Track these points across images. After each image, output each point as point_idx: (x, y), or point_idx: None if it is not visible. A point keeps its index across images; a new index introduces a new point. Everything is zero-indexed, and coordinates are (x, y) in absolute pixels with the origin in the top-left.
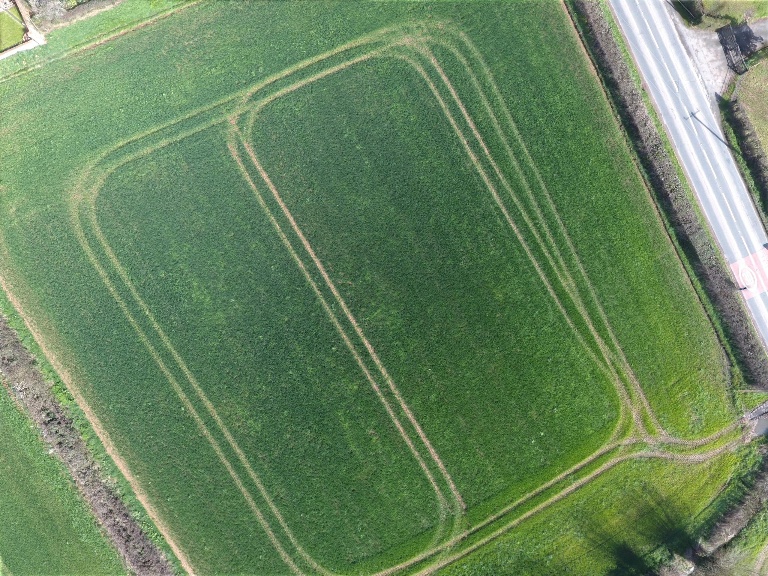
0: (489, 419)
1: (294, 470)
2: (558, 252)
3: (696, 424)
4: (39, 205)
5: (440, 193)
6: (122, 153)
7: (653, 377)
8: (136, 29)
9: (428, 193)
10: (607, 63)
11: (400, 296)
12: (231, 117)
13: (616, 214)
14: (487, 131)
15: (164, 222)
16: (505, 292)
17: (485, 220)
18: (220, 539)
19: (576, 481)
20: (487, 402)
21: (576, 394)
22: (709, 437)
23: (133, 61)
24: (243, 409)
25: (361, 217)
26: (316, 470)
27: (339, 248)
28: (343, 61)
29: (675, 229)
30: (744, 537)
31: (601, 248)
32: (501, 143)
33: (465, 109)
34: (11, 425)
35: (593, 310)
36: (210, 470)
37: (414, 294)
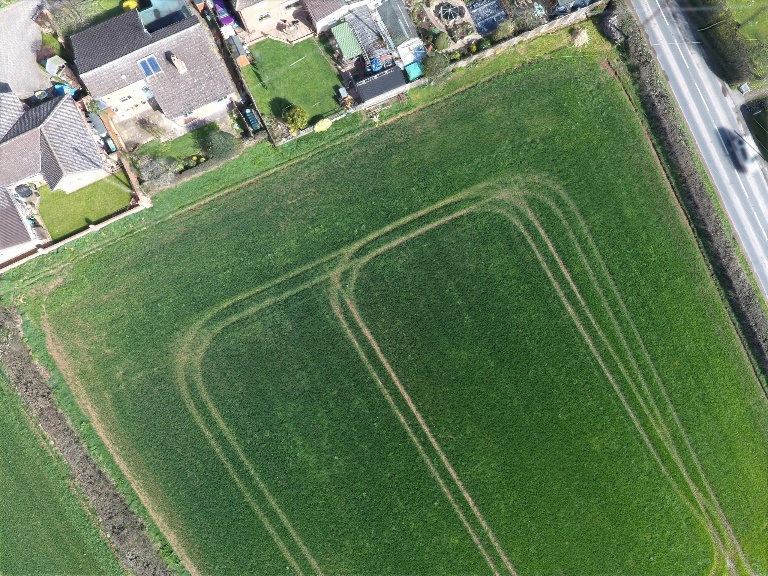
0: (587, 569)
1: None
2: (653, 401)
3: None
4: (146, 368)
5: (538, 346)
6: (228, 314)
7: (746, 522)
8: (240, 188)
9: (527, 346)
10: (701, 216)
11: (500, 449)
12: (334, 274)
13: (709, 362)
14: (584, 283)
15: (269, 382)
16: (602, 442)
17: (582, 372)
18: None
19: None
20: (585, 552)
21: (672, 542)
22: None
23: (238, 222)
24: (347, 566)
25: (462, 372)
26: None
27: (440, 403)
28: (443, 217)
29: (766, 376)
30: None
31: (695, 396)
32: (597, 295)
33: (562, 261)
34: None
35: (688, 458)
36: None
37: (514, 447)
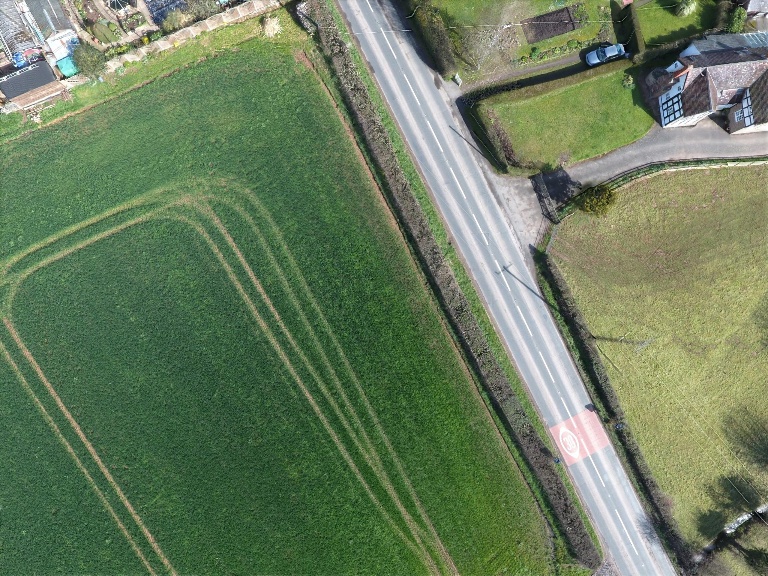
0: None
1: None
2: (359, 423)
3: None
4: None
5: (225, 365)
6: None
7: (468, 554)
8: None
9: (212, 366)
10: (405, 220)
11: (182, 480)
12: None
13: (422, 379)
14: (277, 296)
15: None
16: (300, 470)
17: (276, 392)
18: None
19: None
20: None
21: None
22: None
23: None
24: None
25: (136, 395)
26: None
27: (112, 430)
28: (114, 225)
29: (488, 393)
30: None
31: (407, 417)
32: (293, 308)
33: (253, 272)
34: None
35: (399, 485)
36: None
37: (197, 477)
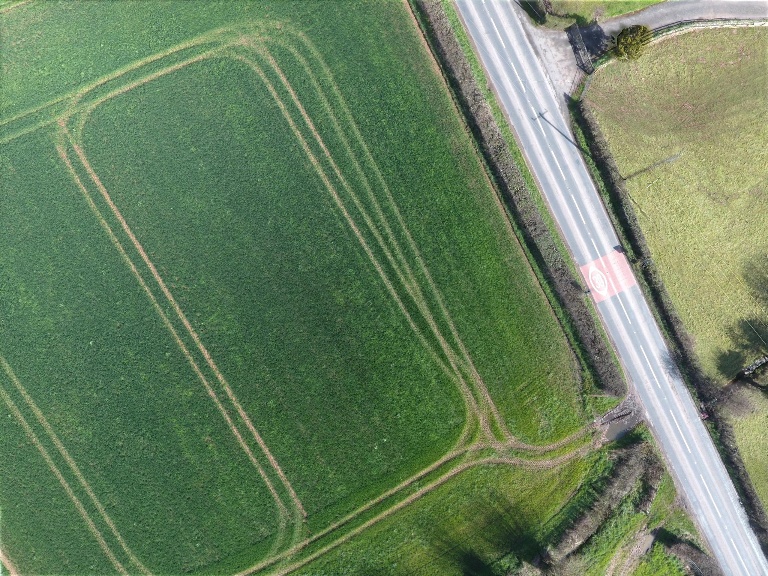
0: (330, 425)
1: (126, 478)
2: (402, 255)
3: (545, 429)
4: None
5: (278, 195)
6: None
7: (501, 382)
8: None
9: (265, 195)
10: (449, 63)
11: (236, 300)
12: (60, 119)
13: (461, 216)
14: (327, 132)
15: None
16: (346, 296)
17: (325, 223)
18: (50, 549)
19: (421, 488)
20: (328, 408)
21: (420, 399)
22: (559, 442)
23: None
24: (73, 416)
25: (196, 220)
26: (150, 478)
27: (173, 252)
28: (177, 61)
29: (522, 231)
30: (595, 544)
31: (446, 251)
32: (341, 144)
33: (304, 110)
34: None
35: (437, 314)
36: (39, 478)
37: (251, 298)
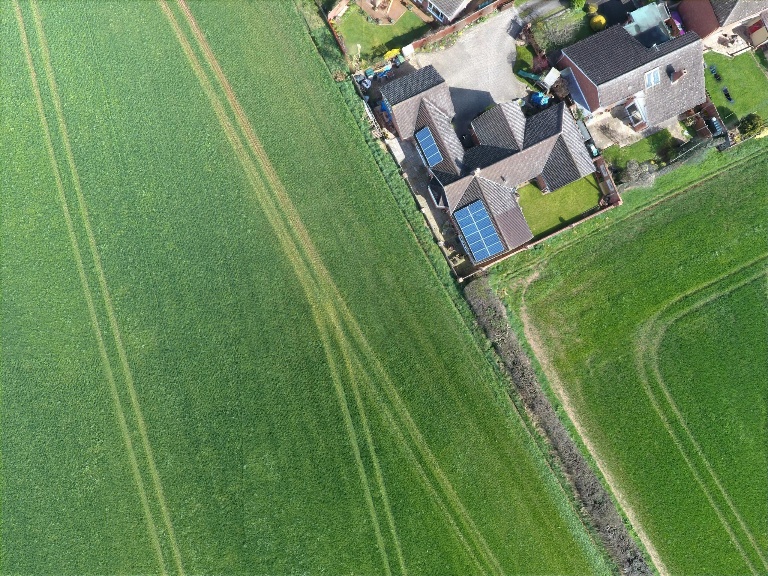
0: None
1: None
2: None
3: None
4: (612, 356)
5: None
6: (681, 307)
7: None
8: (686, 190)
9: None
10: None
11: None
12: None
13: None
14: None
15: (716, 370)
16: None
17: None
18: None
19: None
20: None
21: None
22: None
23: (688, 221)
24: None
25: None
26: None
27: None
28: None
29: None
30: None
31: None
32: None
33: None
34: (587, 560)
35: None
36: None
37: None
